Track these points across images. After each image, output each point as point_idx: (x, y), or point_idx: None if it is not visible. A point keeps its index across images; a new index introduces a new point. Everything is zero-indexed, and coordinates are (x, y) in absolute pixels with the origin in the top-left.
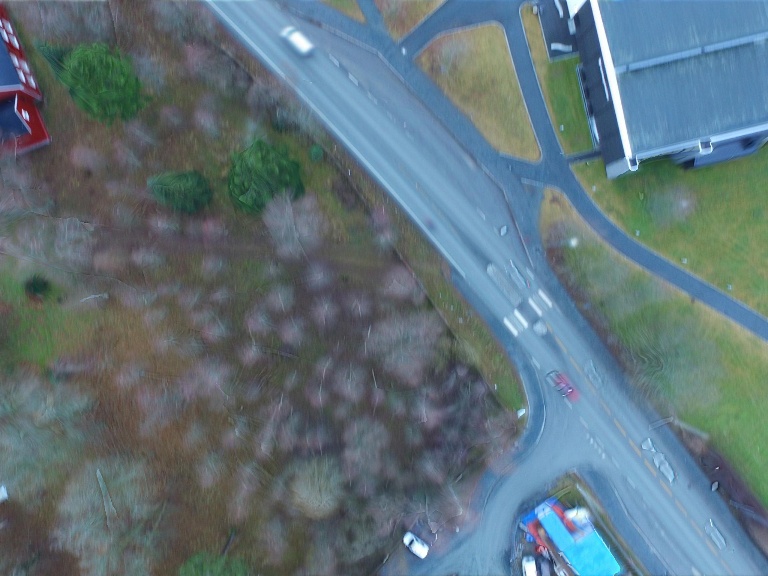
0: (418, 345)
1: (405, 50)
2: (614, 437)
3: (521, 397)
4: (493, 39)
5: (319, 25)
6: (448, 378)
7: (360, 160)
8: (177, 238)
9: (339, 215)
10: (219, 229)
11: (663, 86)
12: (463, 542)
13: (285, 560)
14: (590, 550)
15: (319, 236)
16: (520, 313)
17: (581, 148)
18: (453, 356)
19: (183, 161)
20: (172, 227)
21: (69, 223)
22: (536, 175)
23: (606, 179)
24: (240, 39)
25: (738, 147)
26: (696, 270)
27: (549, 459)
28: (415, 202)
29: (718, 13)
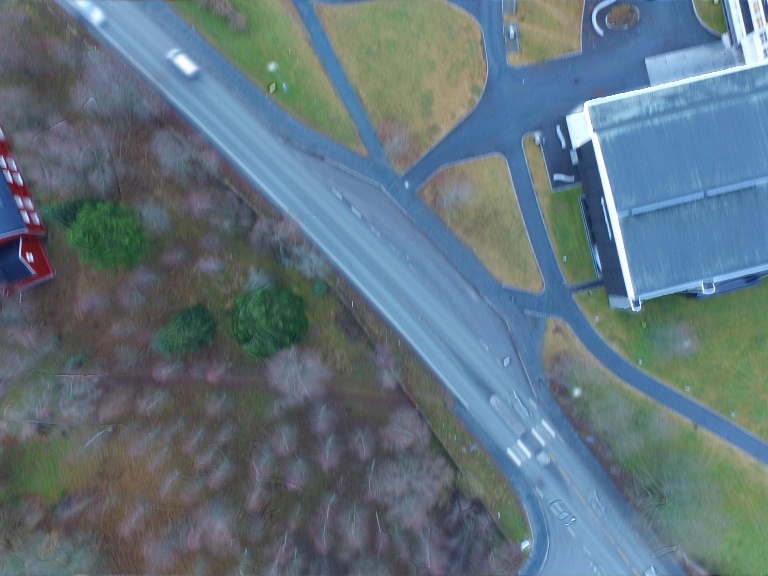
0: (421, 476)
1: (408, 183)
2: (617, 565)
3: (524, 526)
4: (496, 170)
5: (322, 159)
6: (452, 511)
7: (363, 293)
8: (181, 374)
9: (342, 346)
10: (223, 363)
11: (666, 229)
12: None
13: None
14: None
15: (322, 367)
16: (523, 443)
17: (584, 277)
18: (456, 490)
19: (187, 293)
20: (176, 366)
21: (74, 380)
22: (539, 306)
23: (609, 308)
24: (243, 173)
25: (741, 281)
26: (699, 397)
27: None
28: (418, 334)
29: (720, 156)
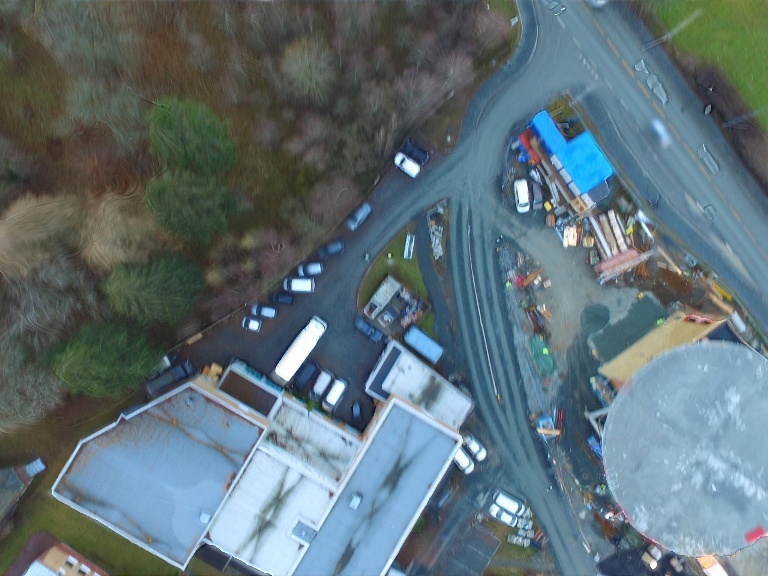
0: None
1: None
2: (607, 57)
3: (514, 15)
4: None
5: None
6: None
7: None
8: None
9: None
10: None
11: None
12: (455, 165)
13: (275, 190)
14: (582, 150)
15: None
16: None
17: None
18: None
19: None
20: None
21: None
22: None
23: None
24: None
25: None
26: None
27: (542, 79)
28: None
29: None
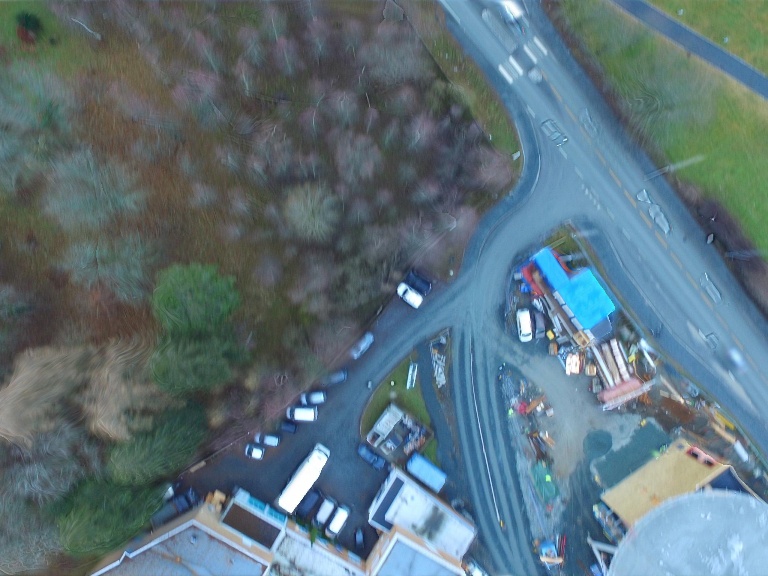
0: (412, 90)
1: None
2: (609, 188)
3: (516, 146)
4: None
5: None
6: (442, 119)
7: None
8: None
9: None
10: None
11: None
12: (457, 295)
13: (278, 317)
14: (585, 287)
15: None
16: (515, 60)
17: None
18: (447, 96)
19: None
20: None
21: None
22: None
23: None
24: None
25: None
26: (692, 24)
27: (544, 210)
28: None
29: None
